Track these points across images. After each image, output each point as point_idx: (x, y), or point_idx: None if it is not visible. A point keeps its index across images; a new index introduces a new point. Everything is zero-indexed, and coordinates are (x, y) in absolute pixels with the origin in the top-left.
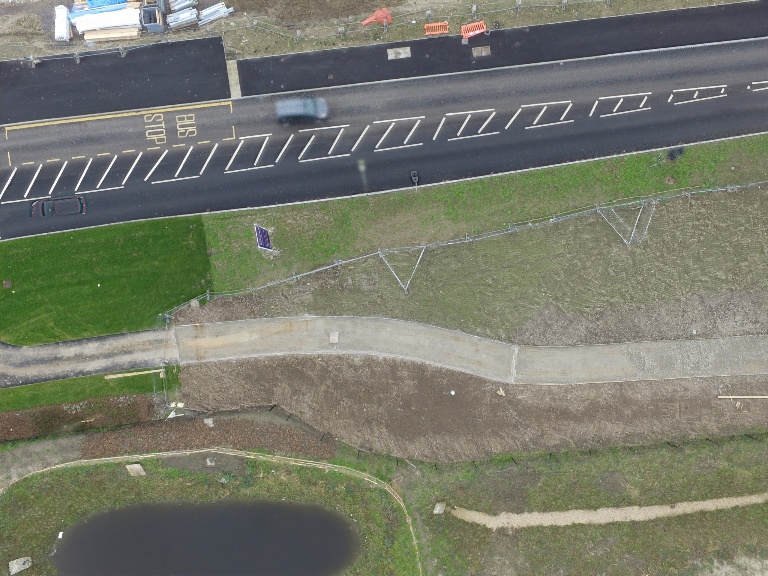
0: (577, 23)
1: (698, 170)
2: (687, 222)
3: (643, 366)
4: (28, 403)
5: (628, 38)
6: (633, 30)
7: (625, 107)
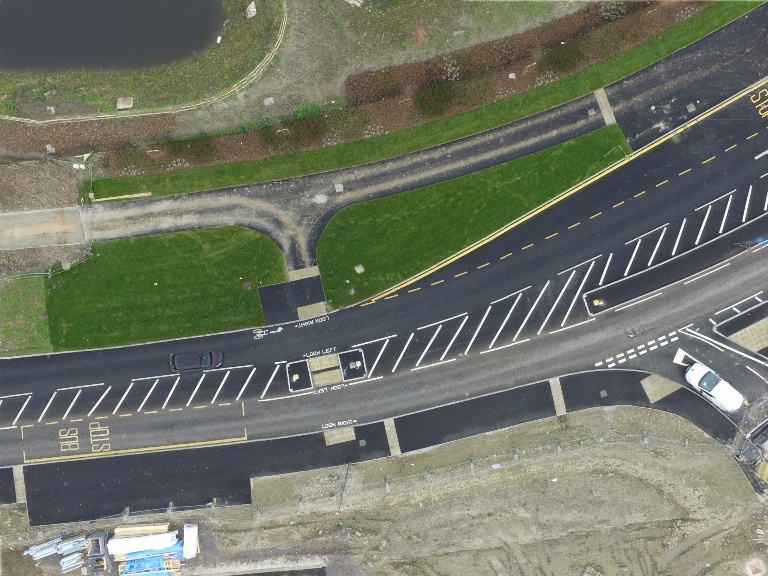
0: None
1: None
2: None
3: None
4: (226, 169)
5: None
6: None
7: None
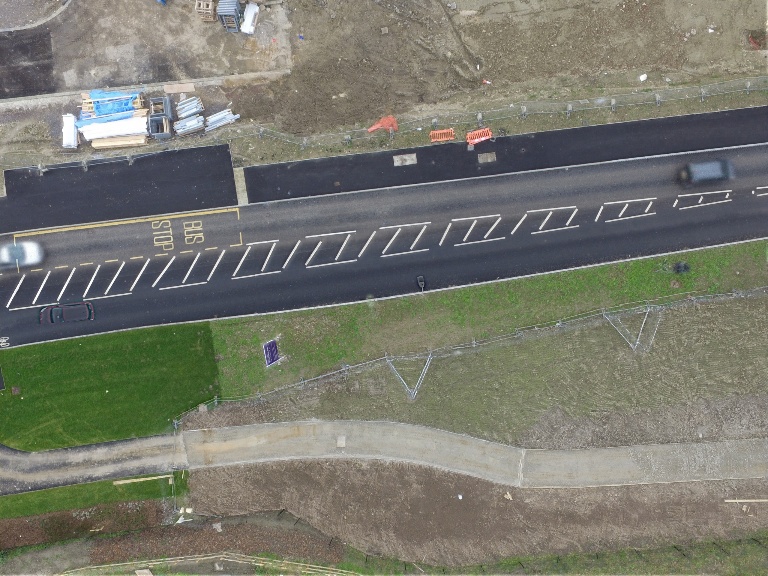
0: (582, 129)
1: (703, 275)
2: (693, 326)
3: (650, 469)
4: (37, 509)
5: (633, 144)
6: (638, 136)
7: (630, 212)
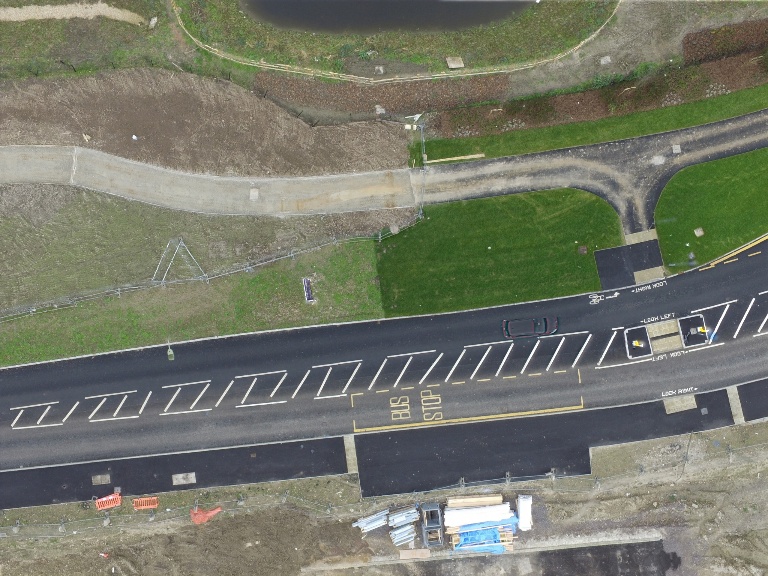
0: (5, 507)
1: None
2: None
3: None
4: (562, 130)
5: None
6: None
7: None
